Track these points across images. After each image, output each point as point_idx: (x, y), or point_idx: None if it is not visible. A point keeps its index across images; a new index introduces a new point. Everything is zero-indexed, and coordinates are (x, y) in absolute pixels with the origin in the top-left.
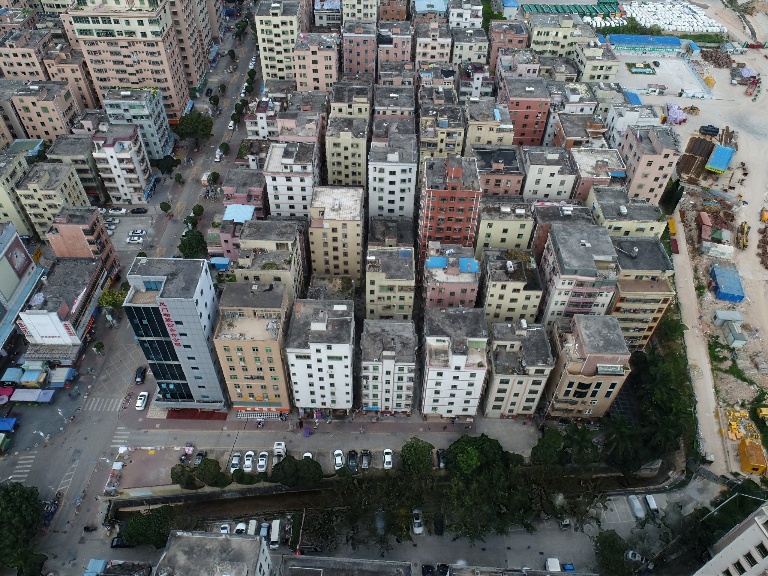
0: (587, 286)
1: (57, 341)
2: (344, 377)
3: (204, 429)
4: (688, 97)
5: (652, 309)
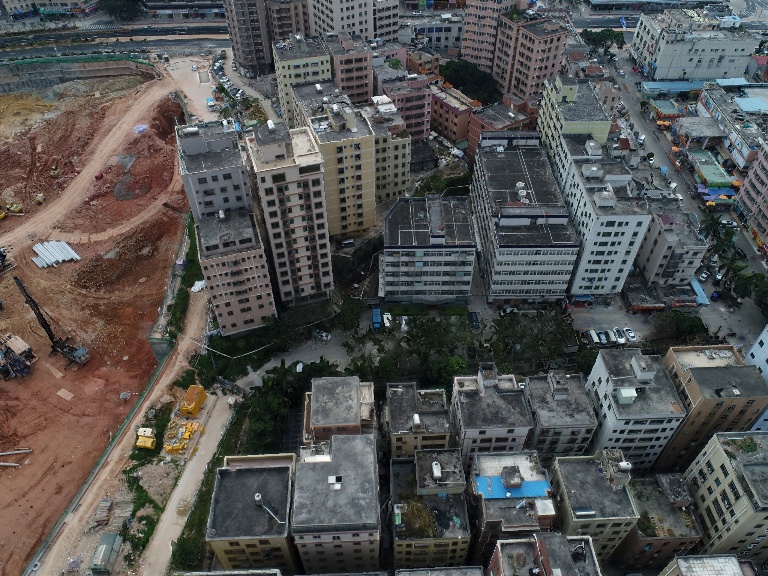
0: None
1: None
2: None
3: None
4: None
5: None
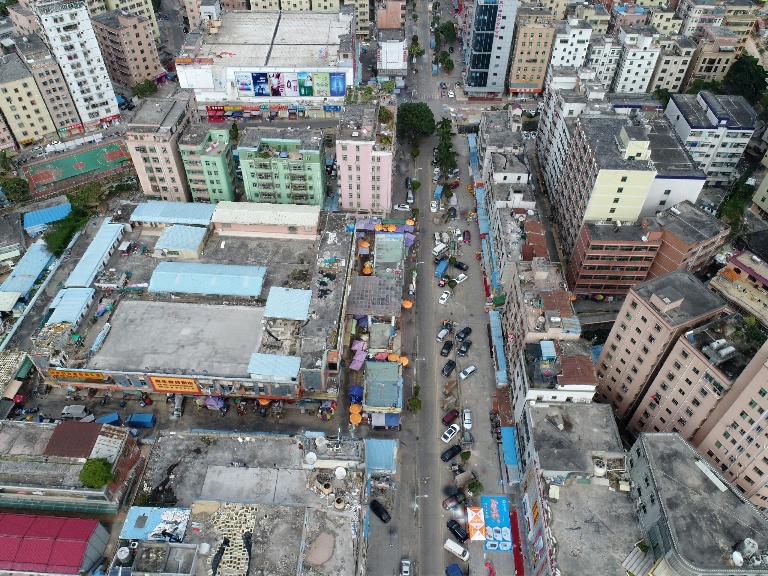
0: (709, 13)
1: (394, 66)
2: (581, 59)
3: (492, 104)
4: None
5: (743, 31)
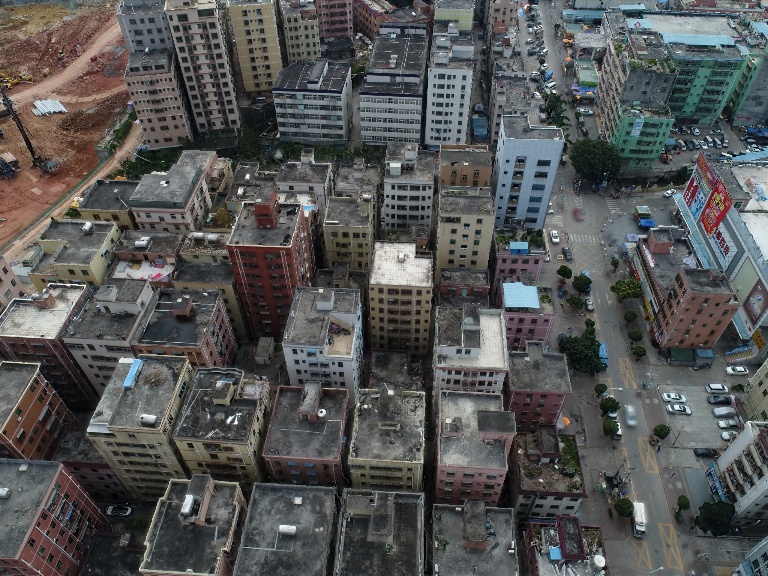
0: None
1: None
2: None
3: None
4: None
5: None
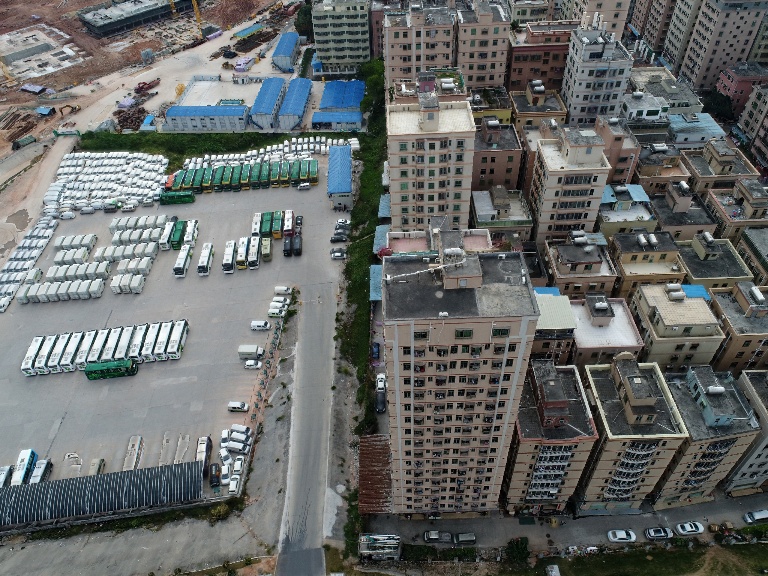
0: None
1: None
2: None
3: None
4: (215, 80)
5: None
